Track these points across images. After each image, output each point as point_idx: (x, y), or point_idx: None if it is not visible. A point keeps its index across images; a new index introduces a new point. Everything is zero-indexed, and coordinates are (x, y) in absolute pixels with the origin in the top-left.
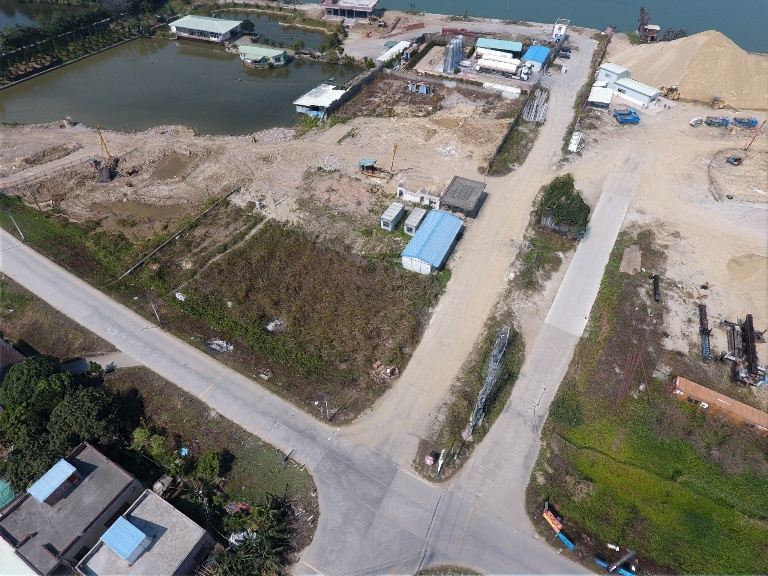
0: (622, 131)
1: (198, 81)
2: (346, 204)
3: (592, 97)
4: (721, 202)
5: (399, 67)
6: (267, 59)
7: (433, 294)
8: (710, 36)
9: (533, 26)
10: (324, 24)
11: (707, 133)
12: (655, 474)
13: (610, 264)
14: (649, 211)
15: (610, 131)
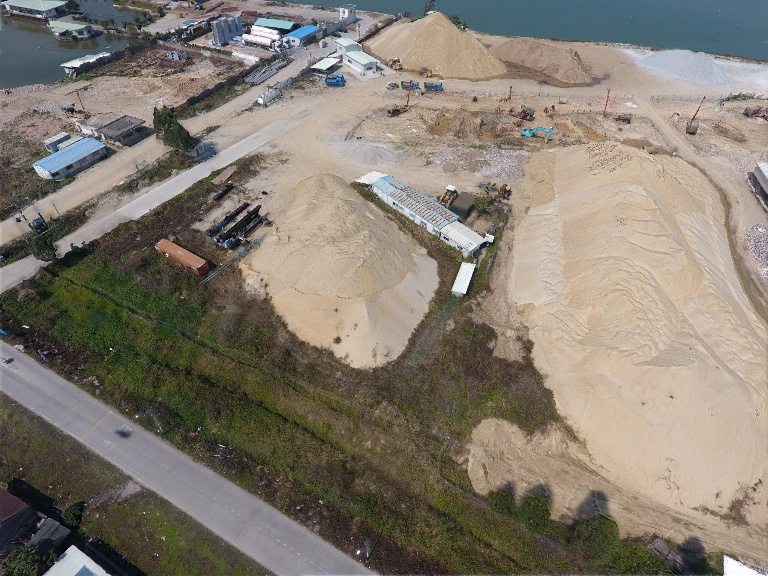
0: (323, 91)
1: (3, 49)
2: (34, 135)
3: (315, 65)
4: (347, 141)
5: (173, 40)
6: (71, 32)
7: (39, 190)
8: (435, 17)
9: (337, 11)
10: (150, 6)
11: (396, 94)
12: (90, 290)
13: (206, 177)
14: (281, 146)
15: (311, 91)
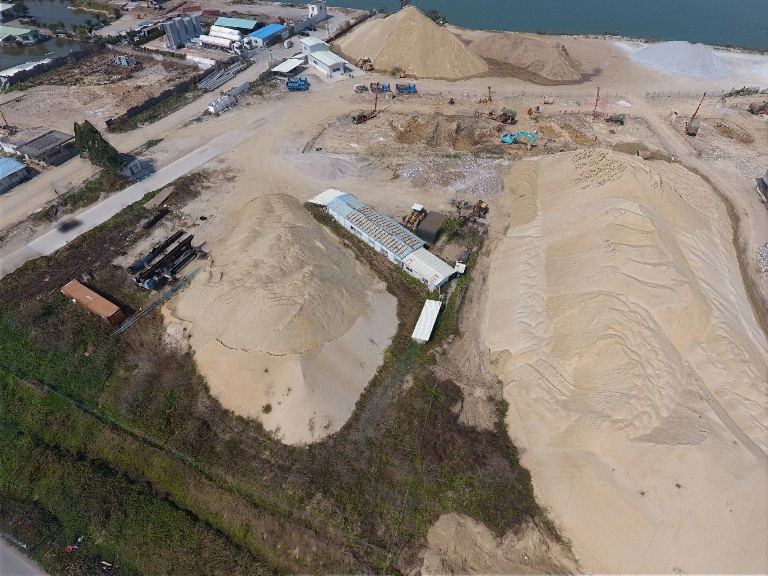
0: (283, 96)
1: None
2: None
3: (277, 67)
4: (305, 153)
5: None
6: (15, 38)
7: None
8: (408, 12)
9: None
10: (107, 7)
11: (364, 98)
12: None
13: (137, 201)
14: (230, 160)
15: (270, 96)
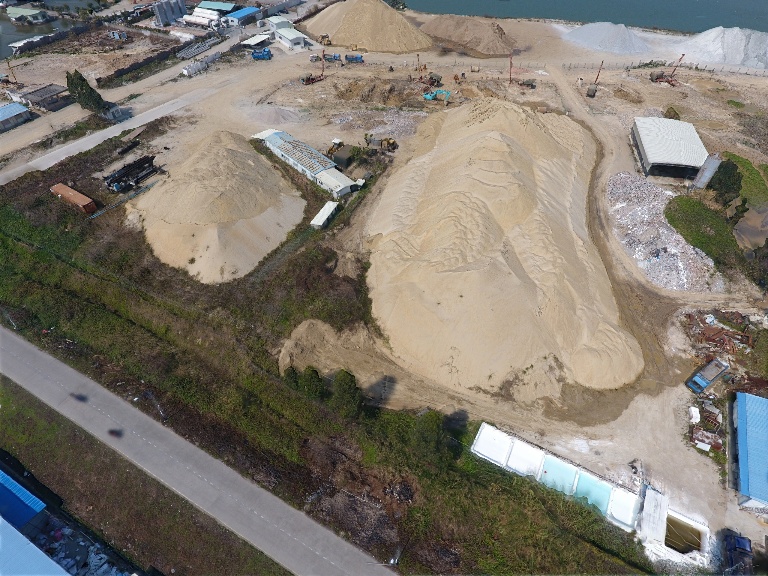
0: (249, 64)
1: None
2: None
3: (246, 41)
4: (258, 105)
5: None
6: (26, 17)
7: None
8: None
9: None
10: None
11: (317, 66)
12: None
13: (116, 136)
14: (195, 110)
15: (237, 64)
